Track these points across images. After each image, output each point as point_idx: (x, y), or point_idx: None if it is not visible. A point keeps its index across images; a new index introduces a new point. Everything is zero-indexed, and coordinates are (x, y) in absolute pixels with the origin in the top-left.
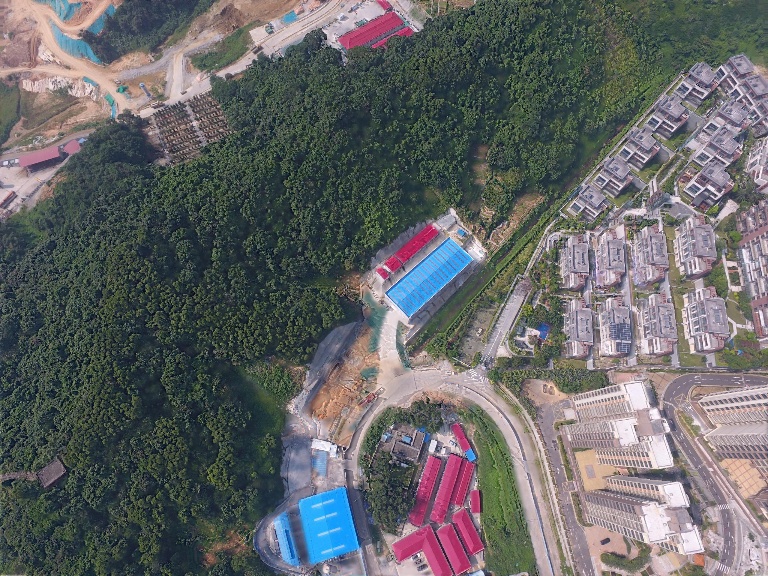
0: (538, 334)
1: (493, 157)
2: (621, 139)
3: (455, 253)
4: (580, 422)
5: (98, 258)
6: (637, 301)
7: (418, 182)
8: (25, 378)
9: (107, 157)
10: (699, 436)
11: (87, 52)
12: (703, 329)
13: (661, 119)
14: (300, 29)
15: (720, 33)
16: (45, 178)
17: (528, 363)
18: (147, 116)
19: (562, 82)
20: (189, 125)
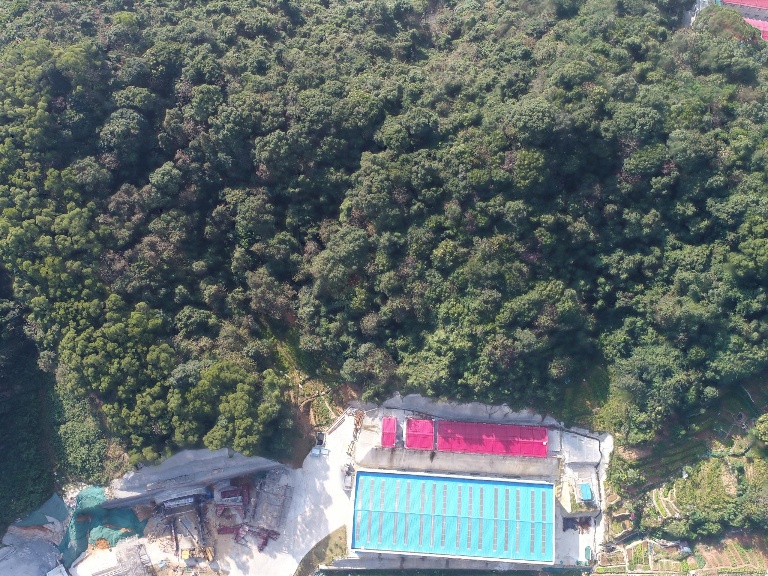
0: None
1: None
2: None
3: (535, 521)
4: None
5: None
6: None
7: (597, 343)
8: None
9: None
10: None
11: None
12: None
13: None
14: None
15: None
16: None
17: None
18: None
19: None
20: None
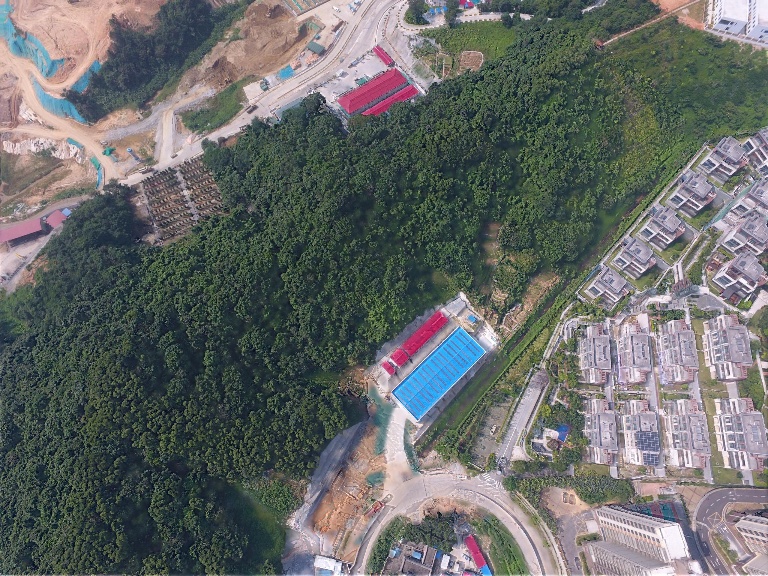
0: (557, 435)
1: (506, 238)
2: (642, 215)
3: (466, 345)
4: (605, 541)
5: (80, 369)
6: (664, 404)
7: (425, 265)
8: (2, 498)
9: (91, 241)
10: (736, 564)
11: (71, 111)
12: (740, 447)
13: (686, 197)
14: (297, 86)
15: (746, 99)
16: (26, 253)
17: (546, 466)
18: (135, 183)
19: (579, 156)
20: (180, 194)
